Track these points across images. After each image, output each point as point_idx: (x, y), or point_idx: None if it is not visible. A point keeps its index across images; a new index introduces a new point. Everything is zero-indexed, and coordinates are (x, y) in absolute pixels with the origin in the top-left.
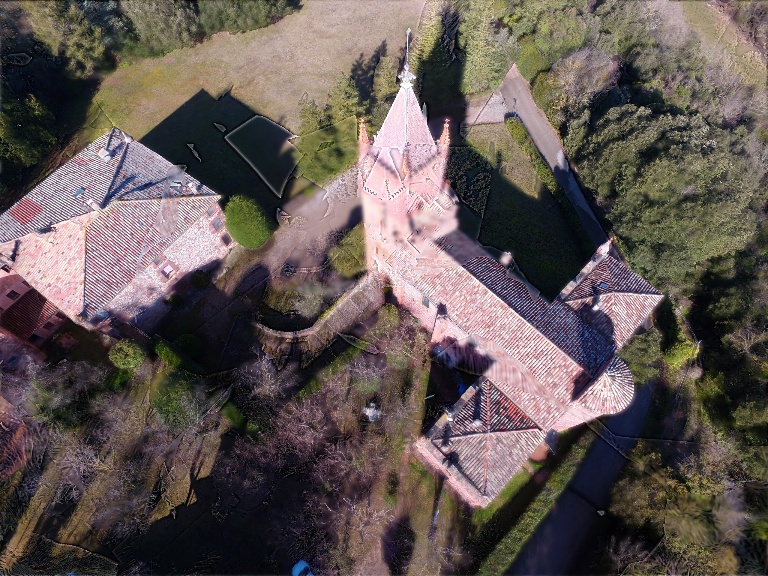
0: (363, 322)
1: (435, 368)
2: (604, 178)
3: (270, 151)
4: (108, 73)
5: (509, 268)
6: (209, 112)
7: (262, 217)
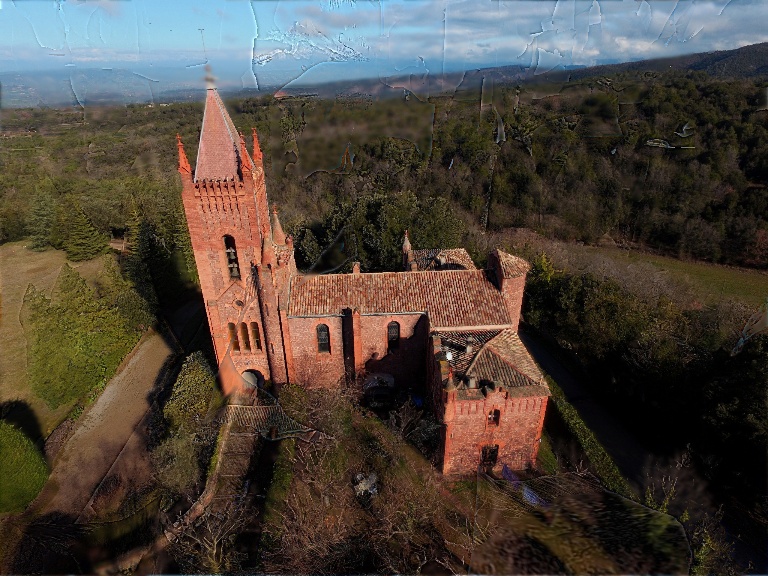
0: (266, 441)
1: (378, 410)
2: (358, 245)
3: None
4: None
5: (406, 97)
6: None
7: None
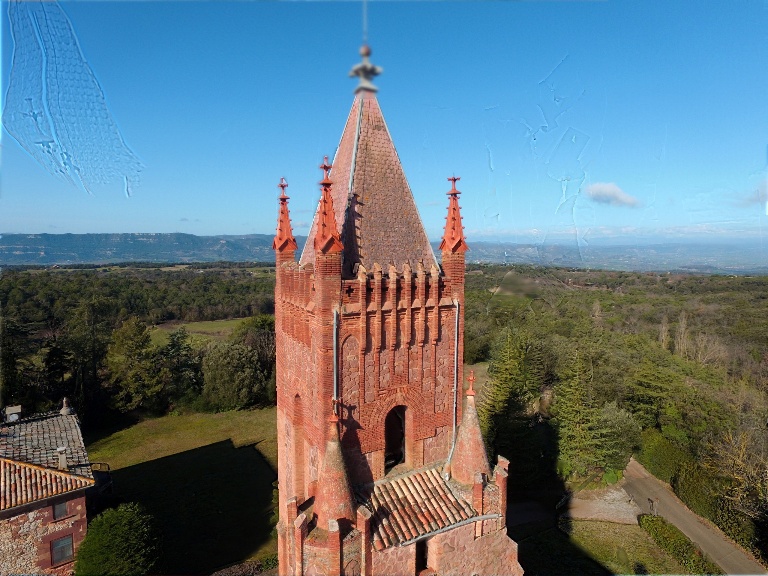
0: None
1: None
2: None
3: None
4: (152, 417)
5: None
6: (217, 456)
7: (148, 560)
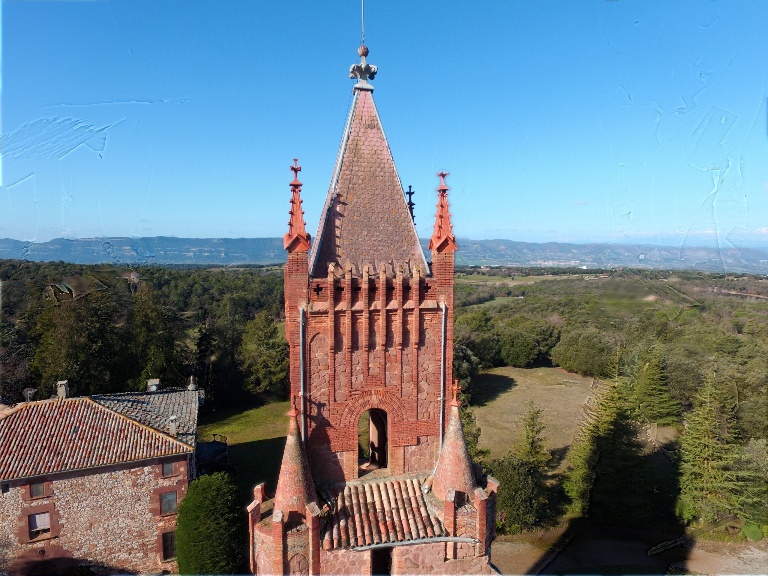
0: None
1: None
2: None
3: None
4: (277, 400)
5: None
6: None
7: (231, 525)
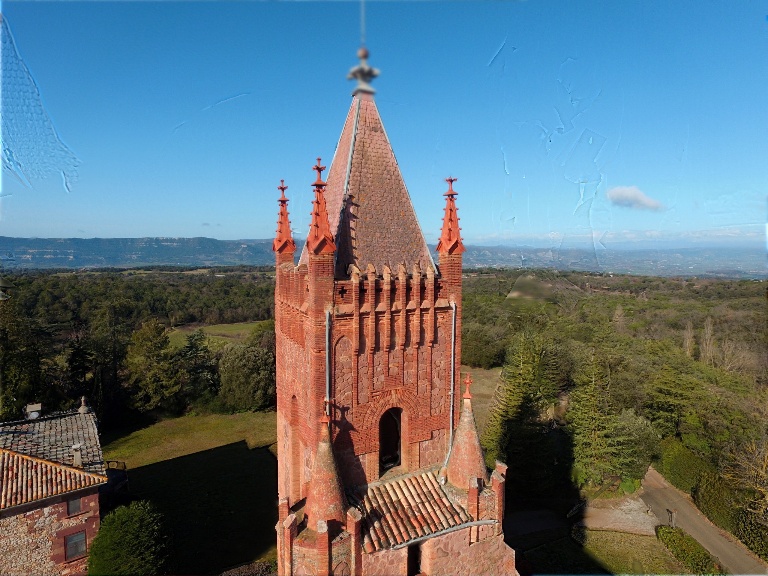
0: None
1: None
2: None
3: None
4: (170, 417)
5: None
6: (232, 457)
7: (158, 558)
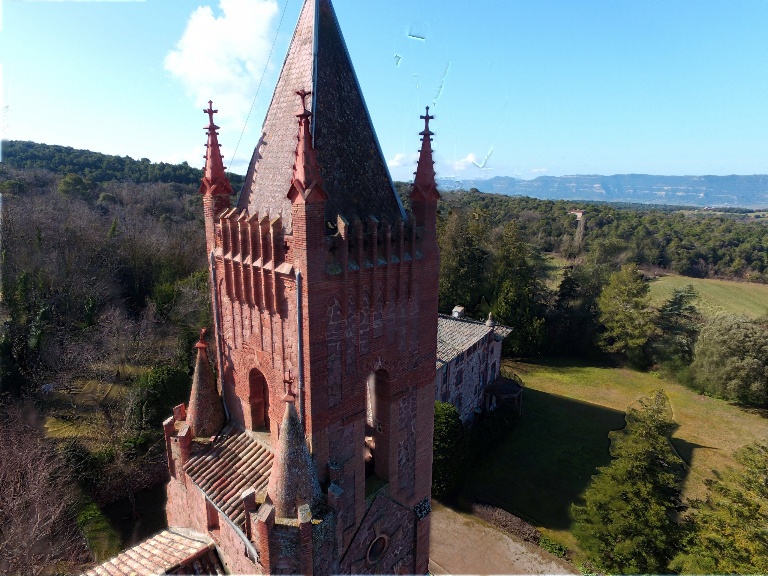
0: None
1: None
2: None
3: (177, 30)
4: (632, 368)
5: None
6: None
7: (440, 452)
